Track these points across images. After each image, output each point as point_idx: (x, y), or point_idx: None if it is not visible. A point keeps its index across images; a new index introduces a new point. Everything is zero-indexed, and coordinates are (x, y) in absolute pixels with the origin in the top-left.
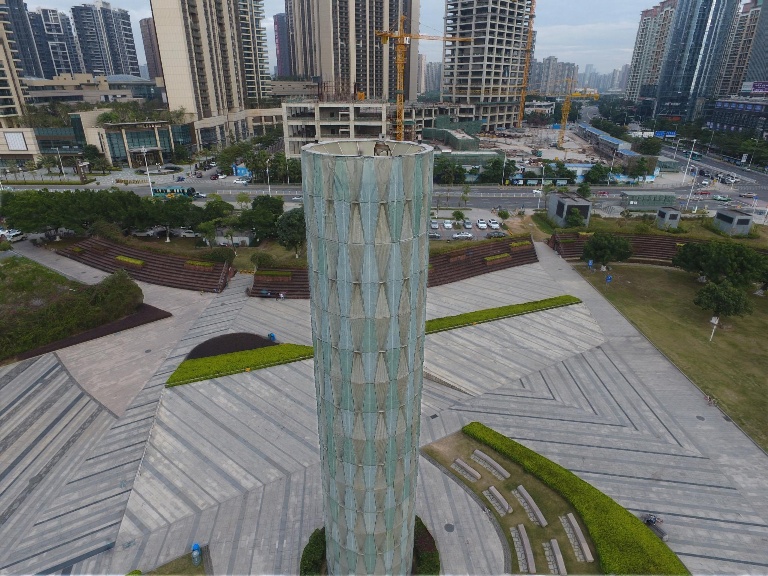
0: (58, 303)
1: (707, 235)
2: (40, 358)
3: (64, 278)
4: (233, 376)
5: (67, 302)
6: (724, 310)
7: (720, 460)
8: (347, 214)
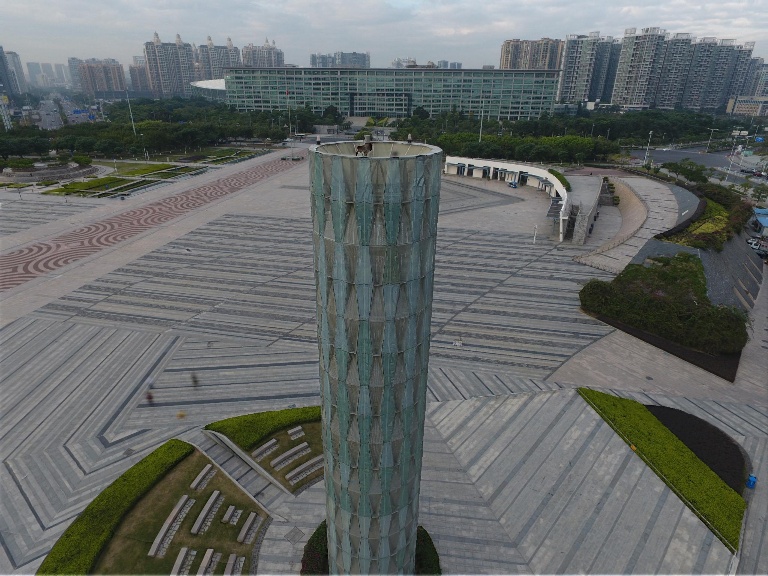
0: (655, 299)
1: None
2: (605, 326)
3: (703, 290)
4: (617, 437)
5: (662, 303)
6: None
7: None
8: None
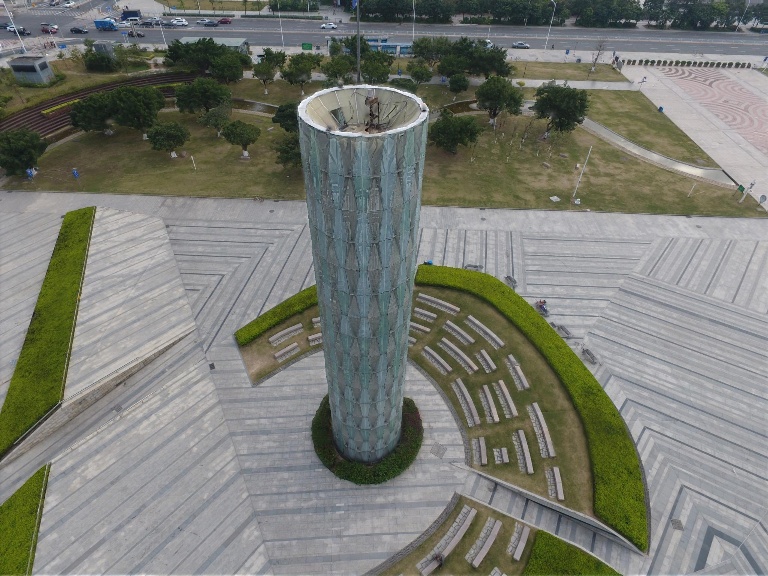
0: None
1: (29, 92)
2: None
3: None
4: None
5: None
6: (178, 142)
7: None
8: (422, 165)
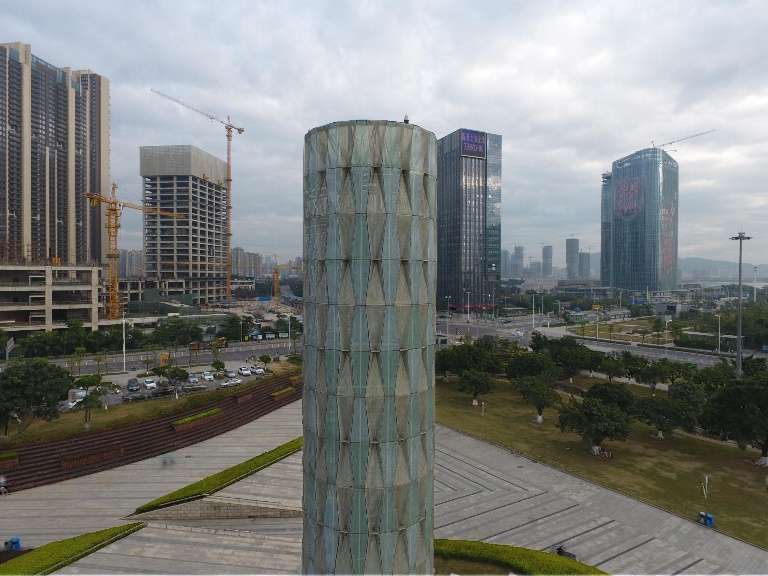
0: None
1: None
2: None
3: None
4: None
5: None
6: (481, 390)
7: (555, 490)
8: (396, 181)
